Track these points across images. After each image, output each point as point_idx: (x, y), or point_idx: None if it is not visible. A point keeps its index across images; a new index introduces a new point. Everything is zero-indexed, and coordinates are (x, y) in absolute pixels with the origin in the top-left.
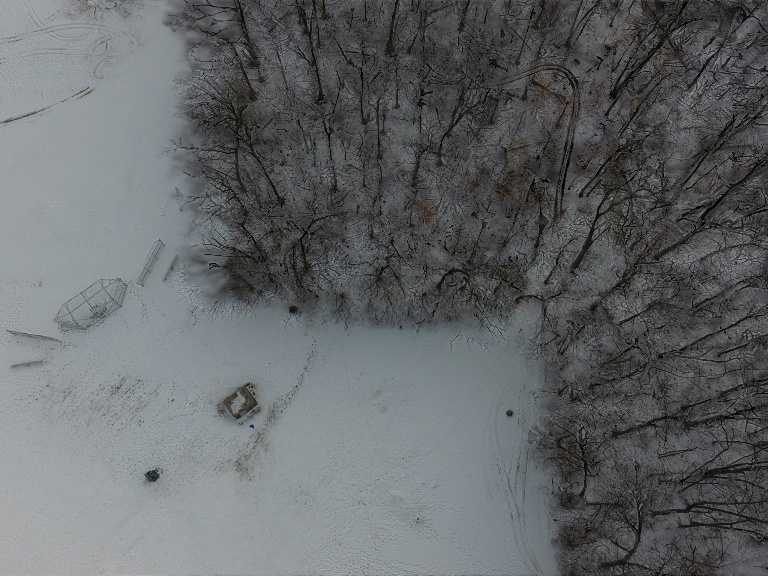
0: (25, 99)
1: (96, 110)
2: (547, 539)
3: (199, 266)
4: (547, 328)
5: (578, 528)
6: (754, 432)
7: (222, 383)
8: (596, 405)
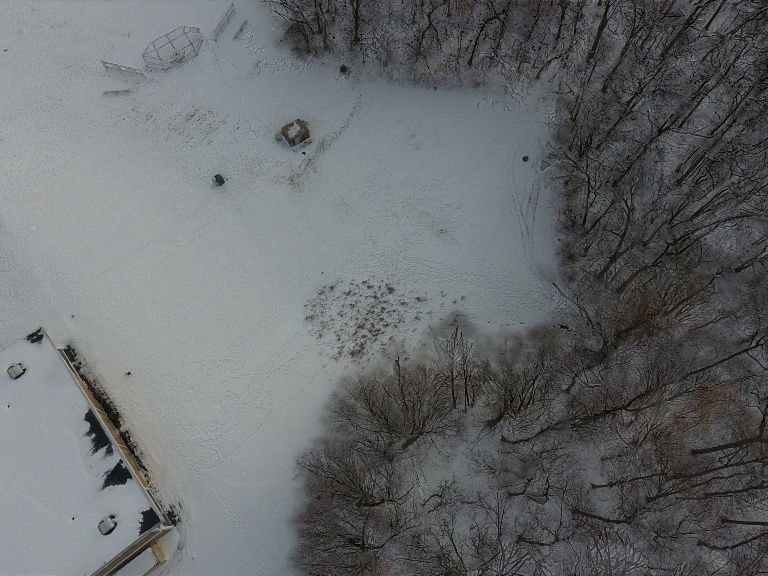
0: None
1: None
2: (551, 253)
3: (264, 30)
4: (562, 99)
5: (579, 244)
6: (737, 183)
7: (280, 119)
8: None
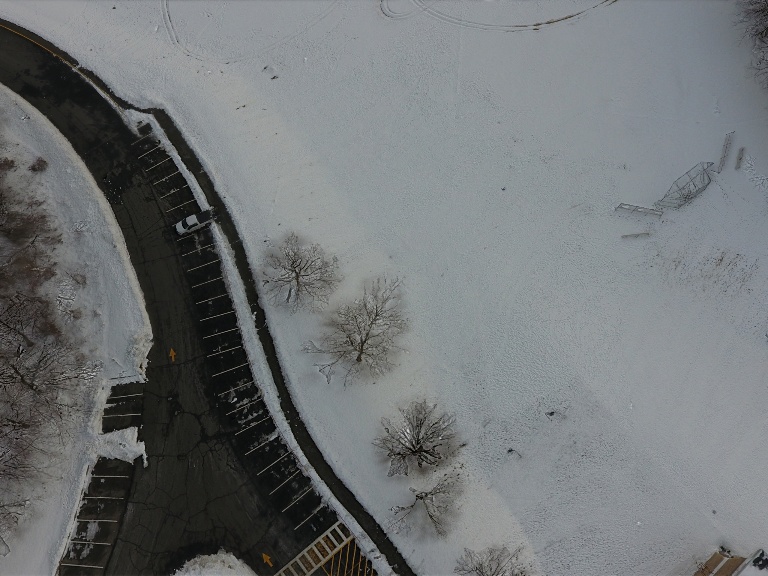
0: (559, 3)
1: (628, 16)
2: None
3: (764, 158)
4: None
5: None
6: None
7: None
8: None
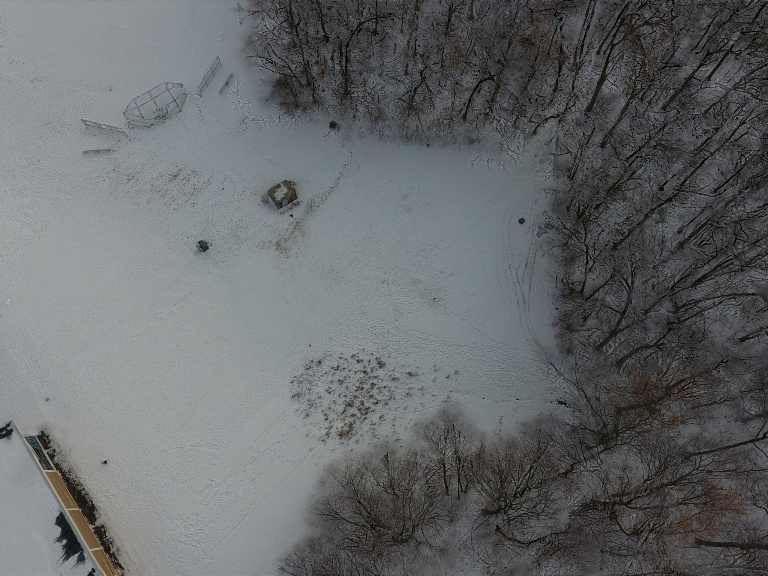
0: None
1: None
2: (548, 323)
3: (251, 84)
4: (560, 156)
5: (577, 314)
6: (742, 248)
7: (267, 179)
8: (600, 223)
